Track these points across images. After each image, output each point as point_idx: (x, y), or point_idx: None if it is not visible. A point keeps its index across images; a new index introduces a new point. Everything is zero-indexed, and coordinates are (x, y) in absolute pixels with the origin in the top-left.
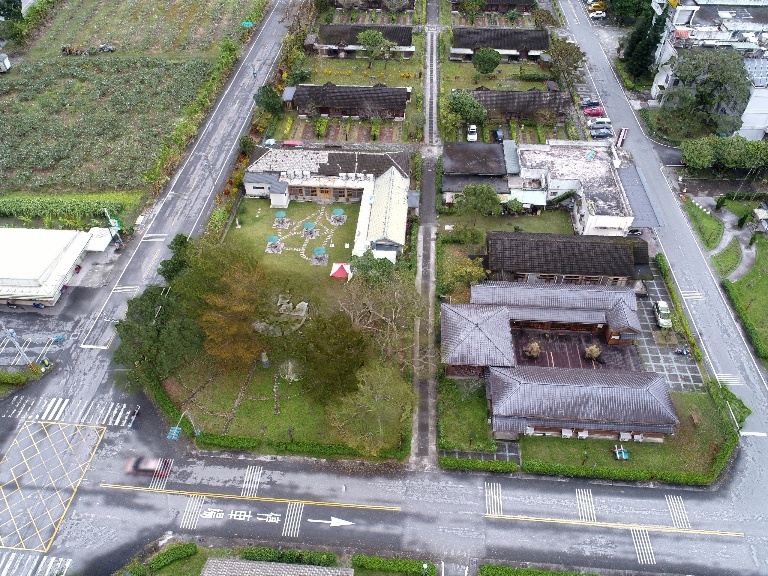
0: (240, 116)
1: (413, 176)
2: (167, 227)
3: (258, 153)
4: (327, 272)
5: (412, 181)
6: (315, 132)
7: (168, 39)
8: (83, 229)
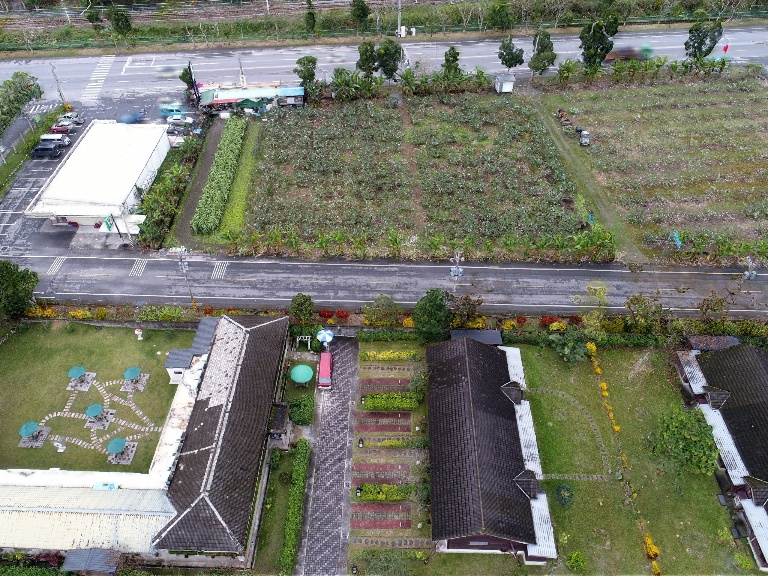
0: (421, 294)
1: (215, 571)
2: (155, 273)
3: (256, 320)
4: (2, 448)
5: (204, 570)
6: (371, 393)
7: (647, 181)
8: (145, 210)
